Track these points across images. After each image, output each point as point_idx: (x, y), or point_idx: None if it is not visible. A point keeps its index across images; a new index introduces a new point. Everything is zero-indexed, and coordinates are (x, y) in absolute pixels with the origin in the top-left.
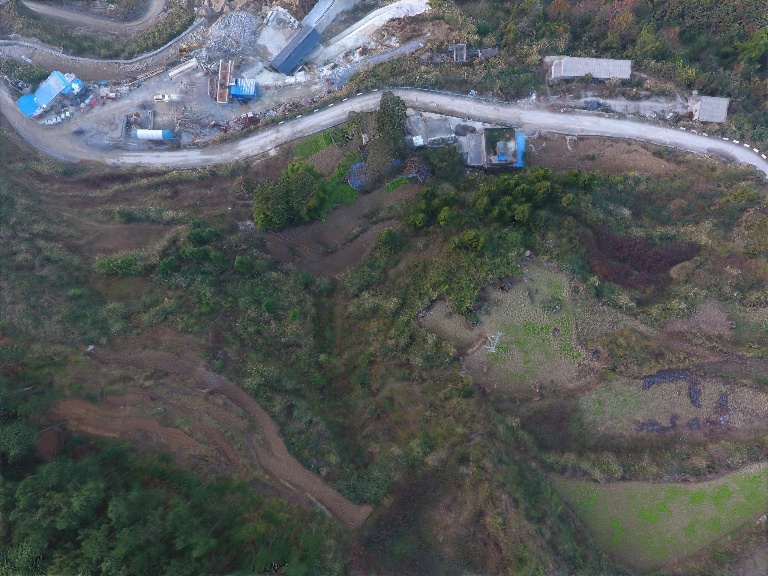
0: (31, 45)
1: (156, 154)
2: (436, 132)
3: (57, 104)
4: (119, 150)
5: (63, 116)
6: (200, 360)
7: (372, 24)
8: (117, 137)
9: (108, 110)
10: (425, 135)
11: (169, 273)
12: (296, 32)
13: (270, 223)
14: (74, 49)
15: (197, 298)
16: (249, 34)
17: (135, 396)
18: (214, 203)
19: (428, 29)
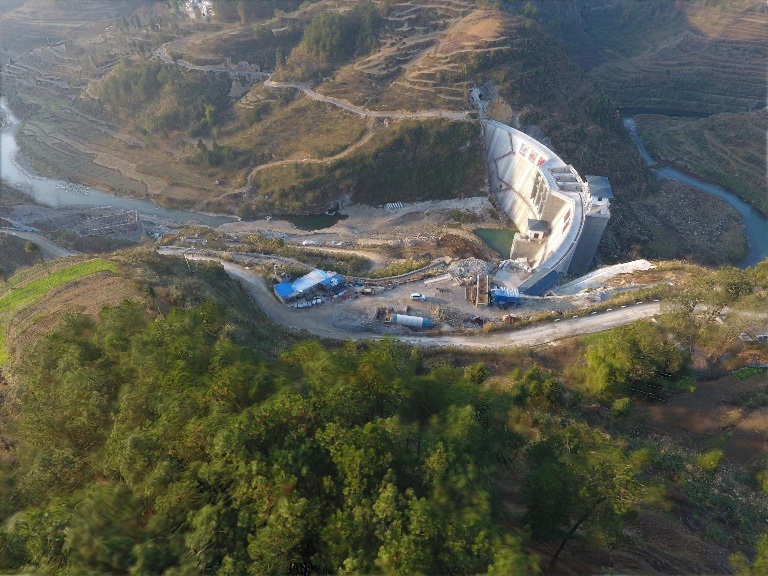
0: (290, 260)
1: (412, 338)
2: (762, 331)
3: (310, 294)
4: (369, 333)
5: (314, 302)
6: (672, 522)
7: (602, 276)
8: (373, 318)
9: (360, 302)
10: (749, 333)
11: (526, 406)
12: (530, 275)
13: (612, 389)
14: (325, 268)
15: (589, 438)
16: (487, 272)
17: (619, 551)
18: (511, 373)
19: (670, 276)
